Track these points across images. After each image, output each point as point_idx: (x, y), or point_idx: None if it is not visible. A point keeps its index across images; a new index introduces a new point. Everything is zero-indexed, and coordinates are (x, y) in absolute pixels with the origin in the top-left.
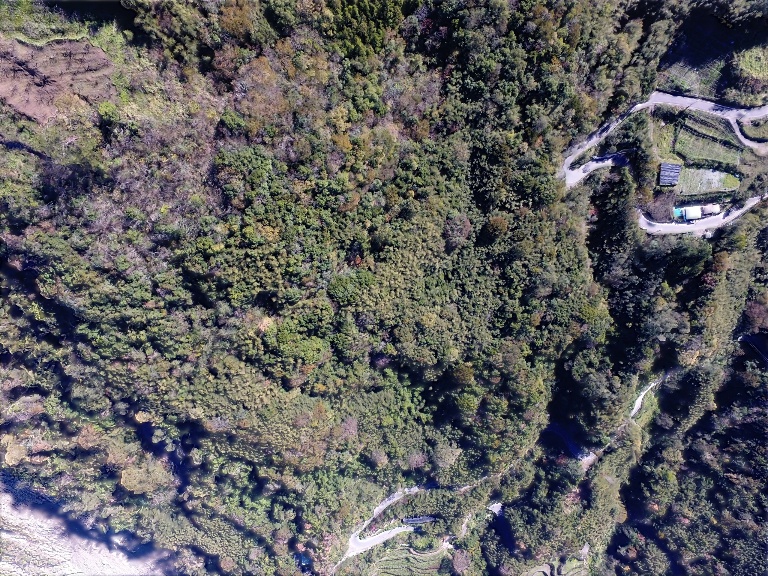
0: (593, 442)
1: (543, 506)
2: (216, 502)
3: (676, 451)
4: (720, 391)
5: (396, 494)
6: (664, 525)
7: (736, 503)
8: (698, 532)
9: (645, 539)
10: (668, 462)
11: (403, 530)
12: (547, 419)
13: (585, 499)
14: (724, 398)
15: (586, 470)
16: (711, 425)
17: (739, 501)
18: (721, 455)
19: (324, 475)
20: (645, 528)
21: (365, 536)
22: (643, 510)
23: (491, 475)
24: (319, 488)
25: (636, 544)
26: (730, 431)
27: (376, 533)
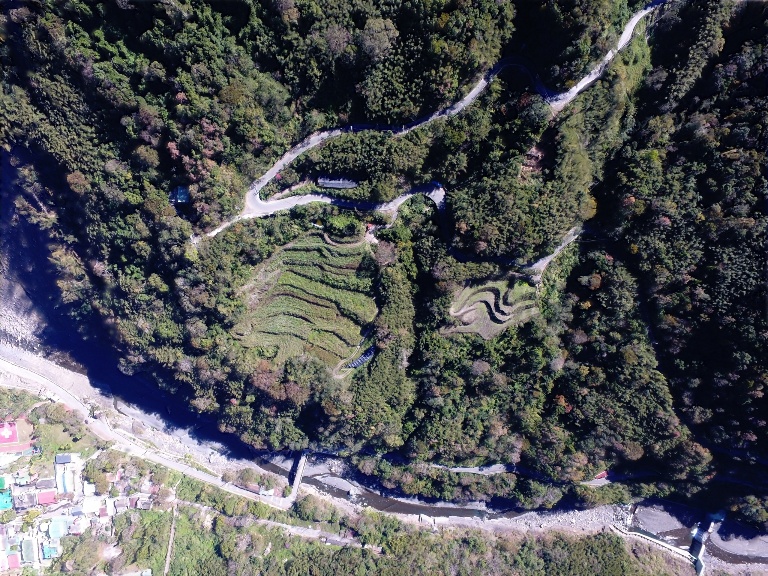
0: (567, 53)
1: (495, 173)
2: (53, 24)
3: (665, 135)
4: (730, 29)
5: (312, 139)
6: (639, 234)
7: (731, 192)
8: (679, 241)
9: (613, 261)
10: (654, 146)
11: (317, 200)
12: (512, 14)
13: (548, 168)
14: (733, 49)
15: (554, 115)
16: (713, 80)
17: (735, 191)
18: (720, 125)
19: (207, 6)
20: (615, 251)
21: (267, 193)
22: (616, 214)
23: (434, 118)
24: (198, 27)
25: (602, 271)
26: (735, 95)
27: (282, 196)
